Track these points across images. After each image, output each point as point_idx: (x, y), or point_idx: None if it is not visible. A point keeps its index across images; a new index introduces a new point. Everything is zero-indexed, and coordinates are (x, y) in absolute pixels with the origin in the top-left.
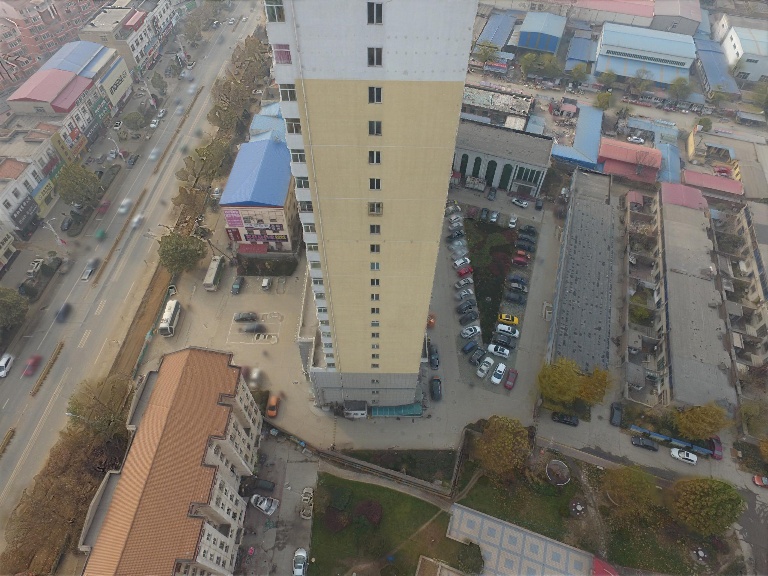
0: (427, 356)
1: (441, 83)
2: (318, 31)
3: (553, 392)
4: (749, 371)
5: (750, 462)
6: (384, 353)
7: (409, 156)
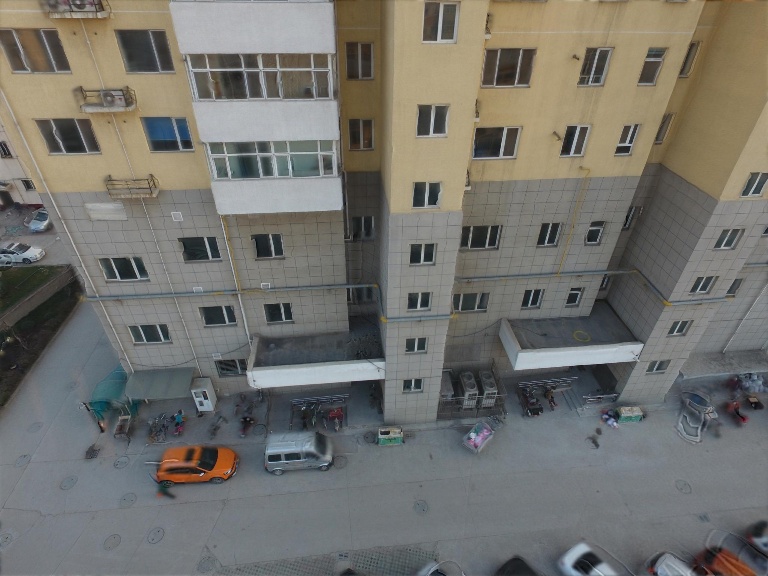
0: (259, 367)
1: None
2: None
3: None
4: None
5: None
6: None
7: None
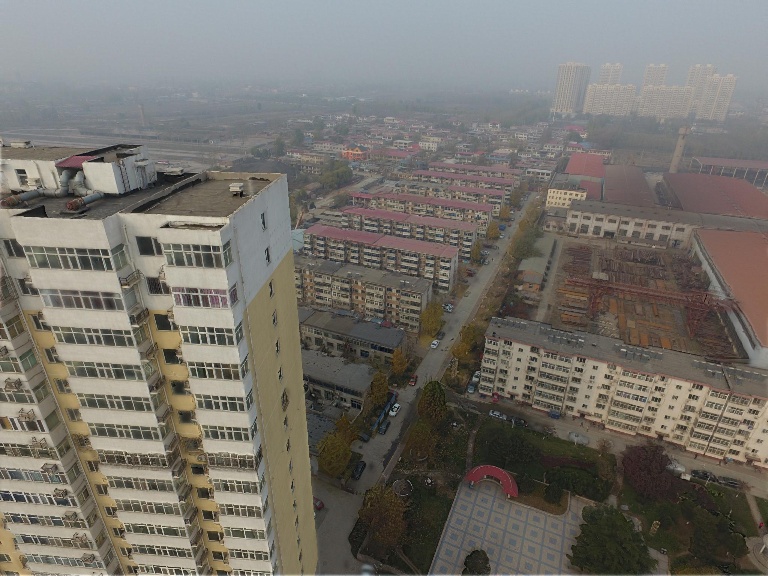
0: None
1: (287, 254)
2: (247, 255)
3: (344, 462)
4: (344, 358)
5: (401, 382)
6: (305, 572)
7: (287, 328)
